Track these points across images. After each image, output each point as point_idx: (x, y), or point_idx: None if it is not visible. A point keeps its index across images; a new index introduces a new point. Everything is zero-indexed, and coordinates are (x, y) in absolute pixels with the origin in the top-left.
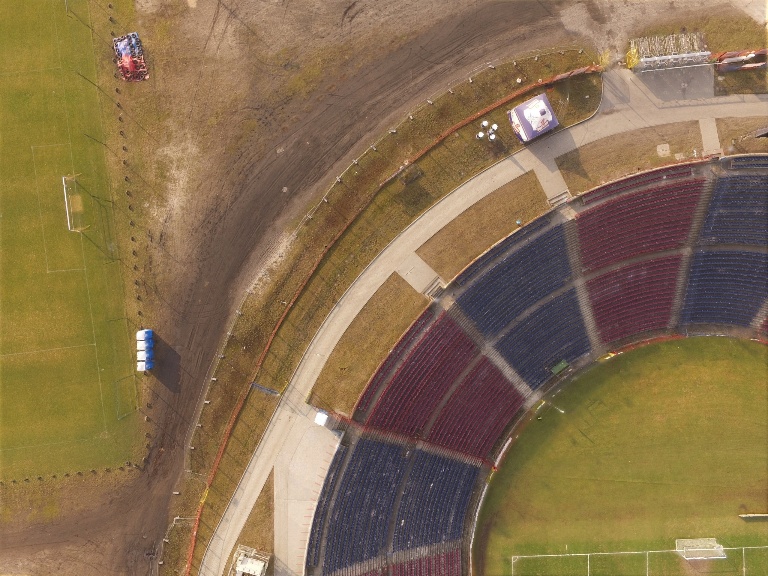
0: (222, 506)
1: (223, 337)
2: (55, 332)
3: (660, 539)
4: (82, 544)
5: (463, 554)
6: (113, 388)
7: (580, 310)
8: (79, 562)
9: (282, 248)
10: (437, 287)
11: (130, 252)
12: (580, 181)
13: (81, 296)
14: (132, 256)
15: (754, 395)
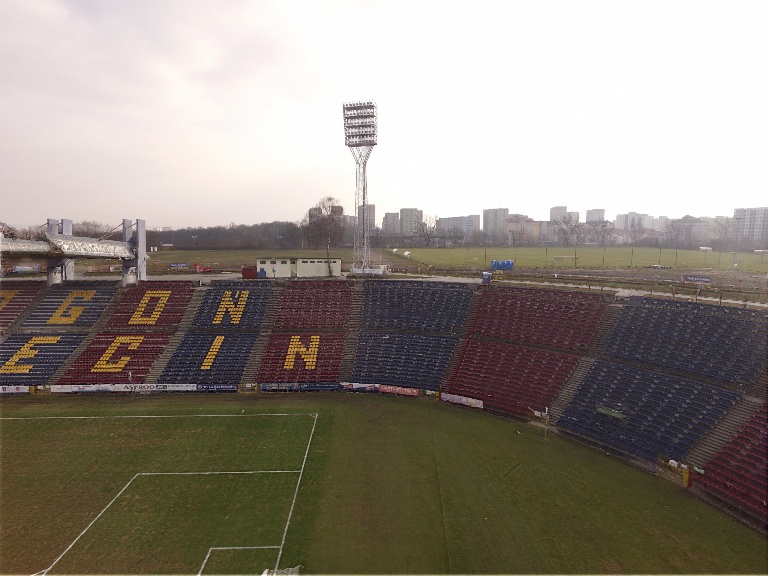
0: None
1: None
2: None
3: (308, 569)
4: None
5: None
6: None
7: (718, 420)
8: None
9: None
10: (627, 299)
11: None
12: None
13: None
14: None
15: None
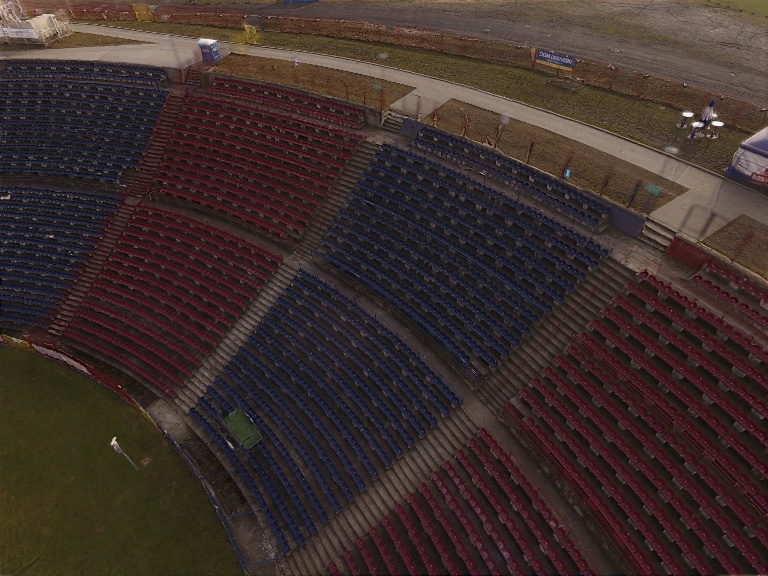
0: (126, 26)
1: None
2: None
3: None
4: None
5: None
6: None
7: (402, 454)
8: None
9: None
10: None
11: None
12: (739, 258)
13: None
14: None
15: None
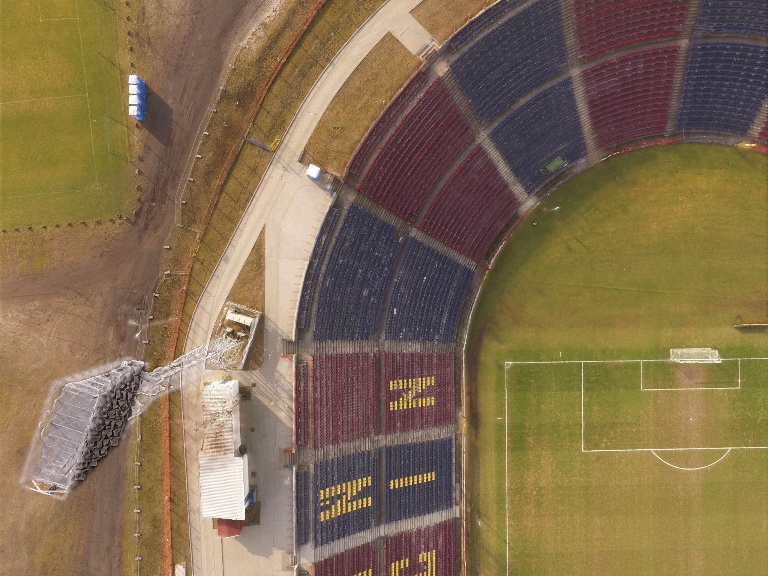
0: (213, 262)
1: (216, 91)
2: (47, 81)
3: (655, 348)
4: (72, 296)
5: (456, 360)
6: (105, 139)
7: (576, 105)
8: (69, 314)
9: (276, 3)
10: (431, 50)
11: (123, 3)
12: None
13: (74, 46)
14: (125, 7)
15: (751, 205)
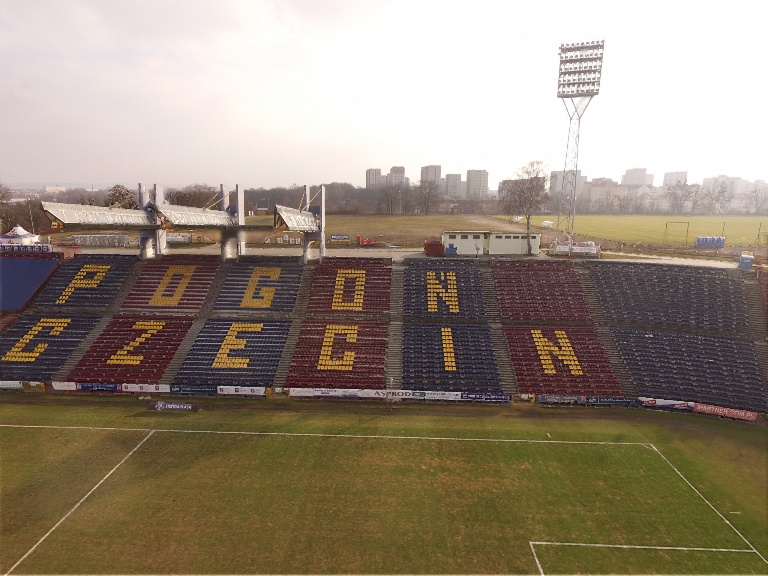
0: None
1: None
2: None
3: None
4: None
5: None
6: None
7: None
8: None
9: None
10: None
11: None
12: None
13: None
14: None
15: None
